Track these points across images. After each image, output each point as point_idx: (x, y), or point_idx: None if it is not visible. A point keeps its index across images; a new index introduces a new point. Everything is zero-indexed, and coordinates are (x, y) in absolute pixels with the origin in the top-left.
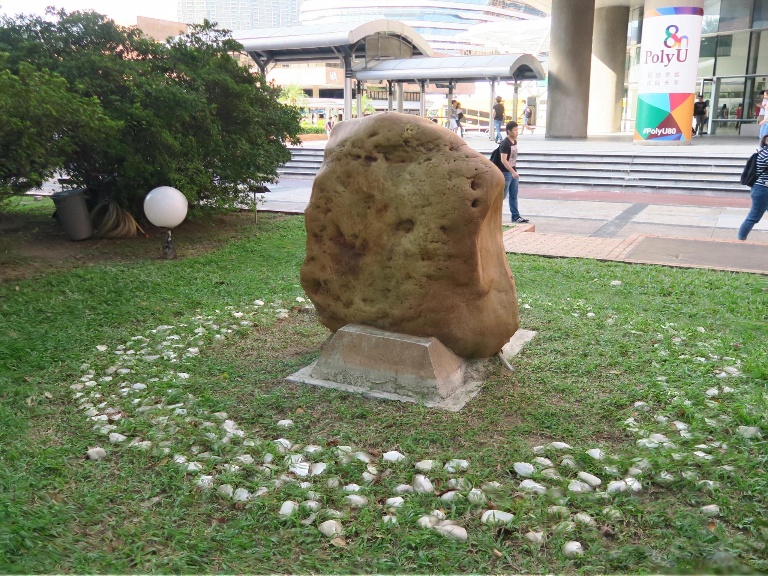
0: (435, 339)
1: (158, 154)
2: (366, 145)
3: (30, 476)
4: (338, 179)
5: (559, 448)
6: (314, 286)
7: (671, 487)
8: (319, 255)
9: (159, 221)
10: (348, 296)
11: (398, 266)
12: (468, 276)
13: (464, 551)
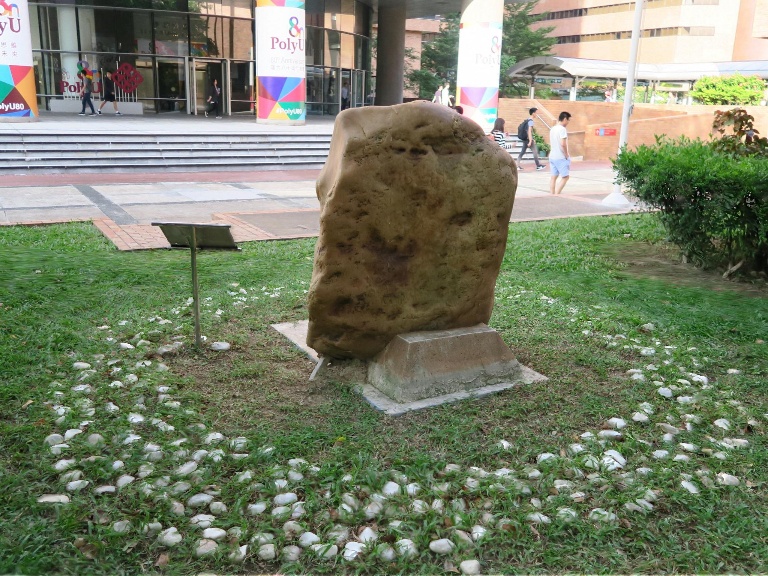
0: None
1: None
2: (413, 137)
3: None
4: (378, 176)
5: None
6: (333, 306)
7: (706, 369)
8: (349, 268)
9: None
10: (395, 306)
11: (455, 261)
12: None
13: (767, 448)
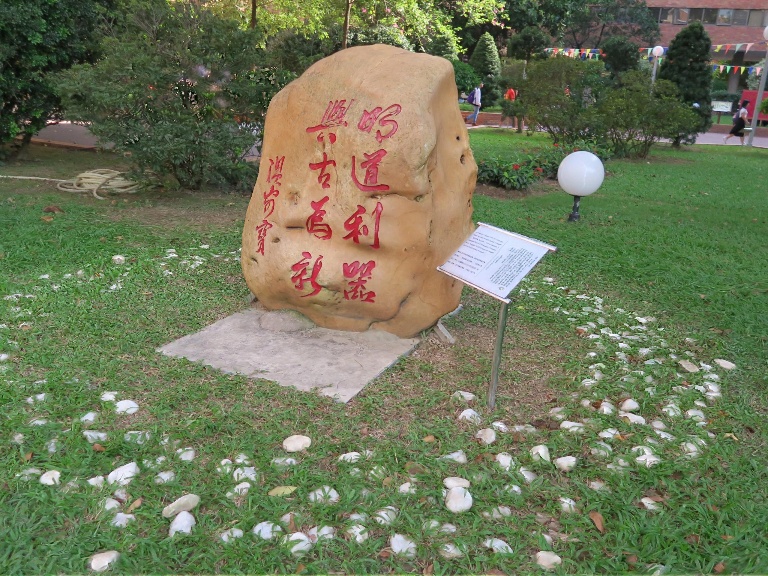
0: None
1: None
2: None
3: None
4: None
5: None
6: None
7: None
8: None
9: None
10: None
11: None
12: None
13: None
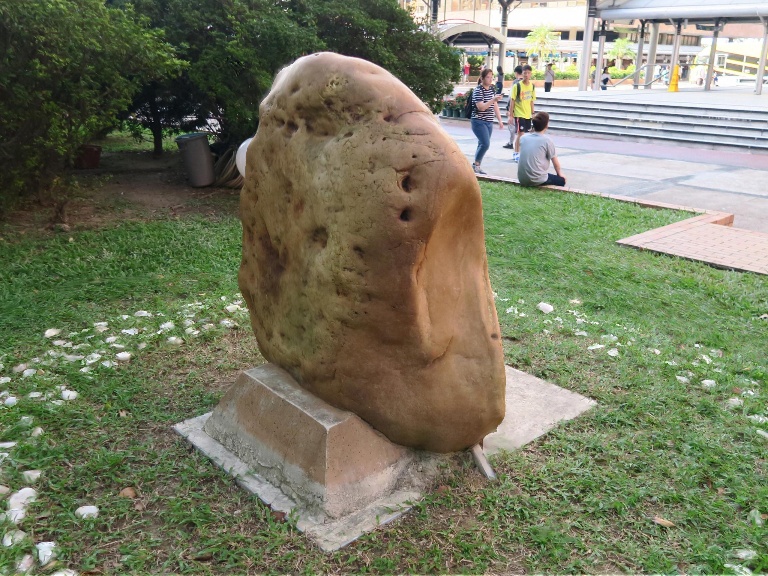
0: (351, 417)
1: (259, 99)
2: (288, 105)
3: None
4: (263, 153)
5: None
6: None
7: None
8: (249, 258)
9: None
10: (269, 324)
11: (312, 296)
12: (400, 330)
13: None
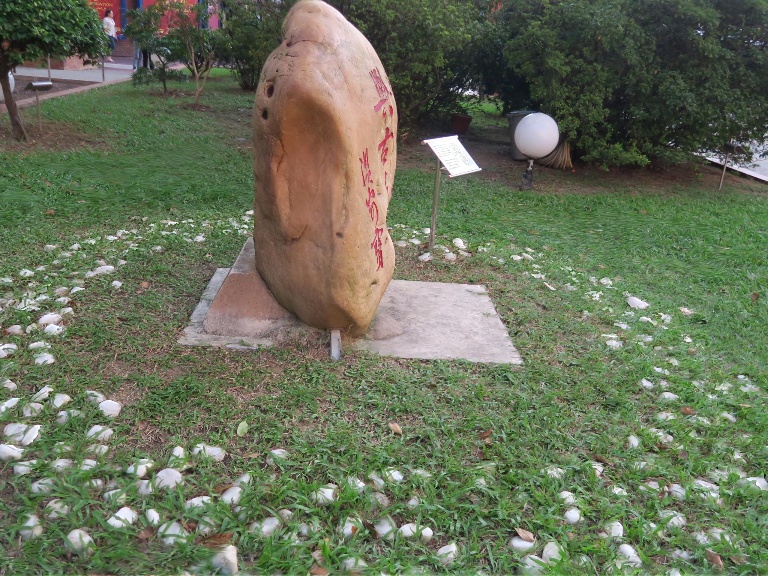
0: (254, 273)
1: (551, 78)
2: None
3: None
4: None
5: None
6: None
7: None
8: None
9: (521, 147)
10: None
11: None
12: None
13: None
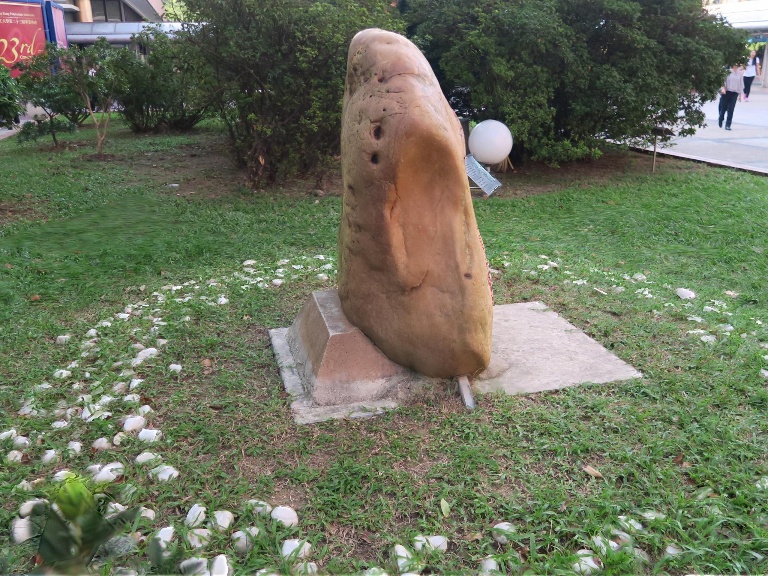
0: (355, 331)
1: (494, 85)
2: None
3: (1, 339)
4: None
5: (272, 516)
6: None
7: None
8: None
9: (476, 156)
10: None
11: None
12: (380, 258)
13: None
